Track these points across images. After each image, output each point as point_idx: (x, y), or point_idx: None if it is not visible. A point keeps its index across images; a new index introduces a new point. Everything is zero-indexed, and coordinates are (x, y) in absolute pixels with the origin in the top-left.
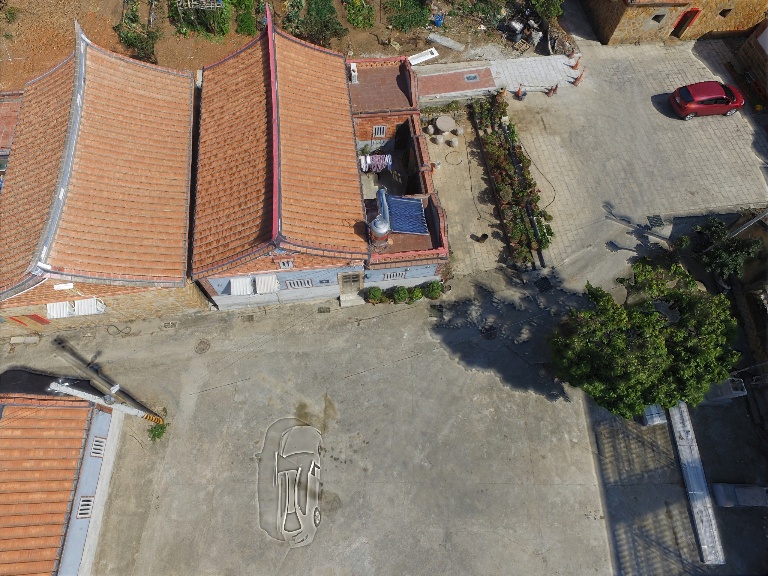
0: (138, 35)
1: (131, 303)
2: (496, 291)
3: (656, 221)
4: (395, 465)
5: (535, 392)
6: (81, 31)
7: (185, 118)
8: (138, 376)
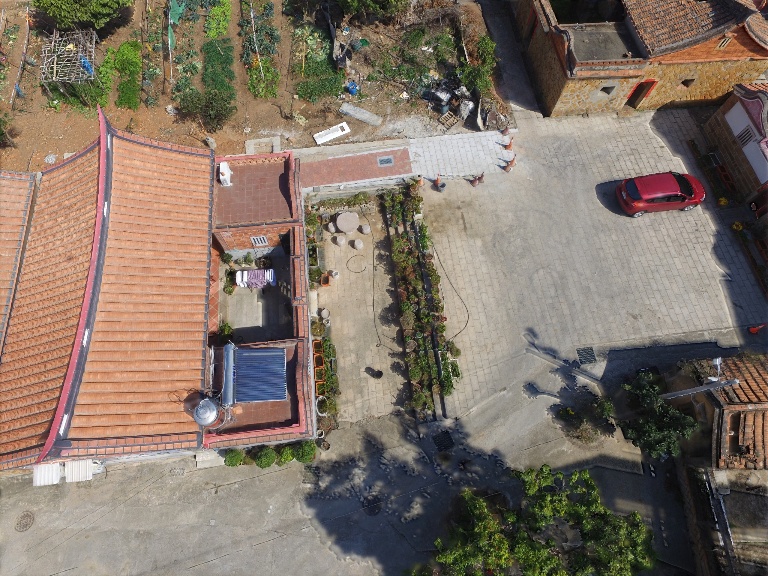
0: None
1: None
2: (386, 448)
3: (587, 355)
4: None
5: None
6: None
7: (13, 237)
8: None
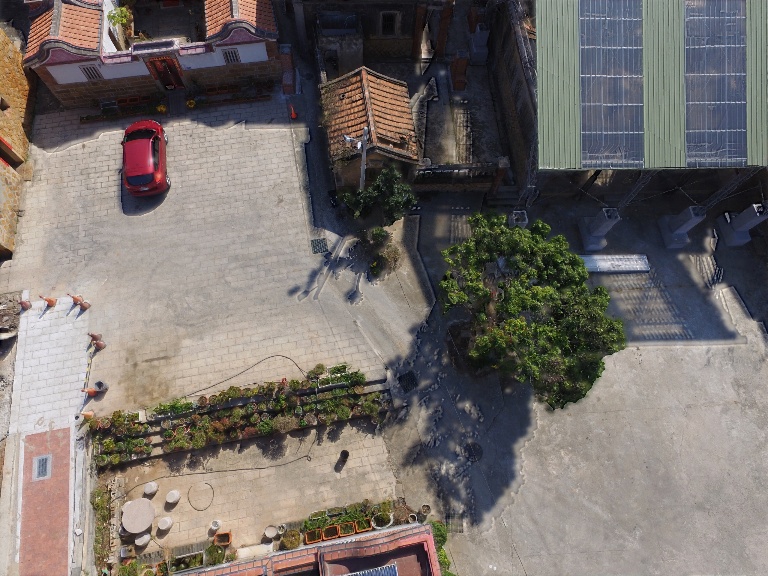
0: None
1: None
2: (420, 441)
3: (319, 245)
4: (648, 573)
5: (534, 402)
6: None
7: None
8: None
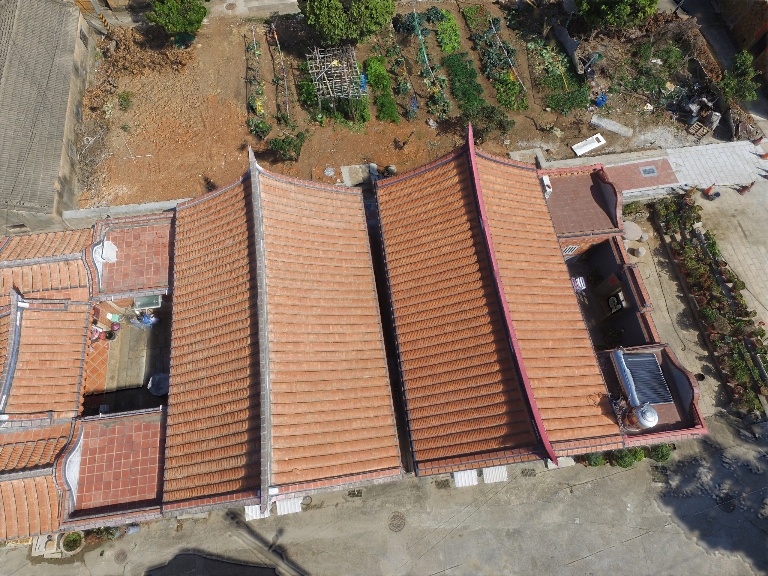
0: (287, 137)
1: None
2: (724, 448)
3: None
4: None
5: None
6: (254, 159)
7: (363, 249)
8: (330, 563)
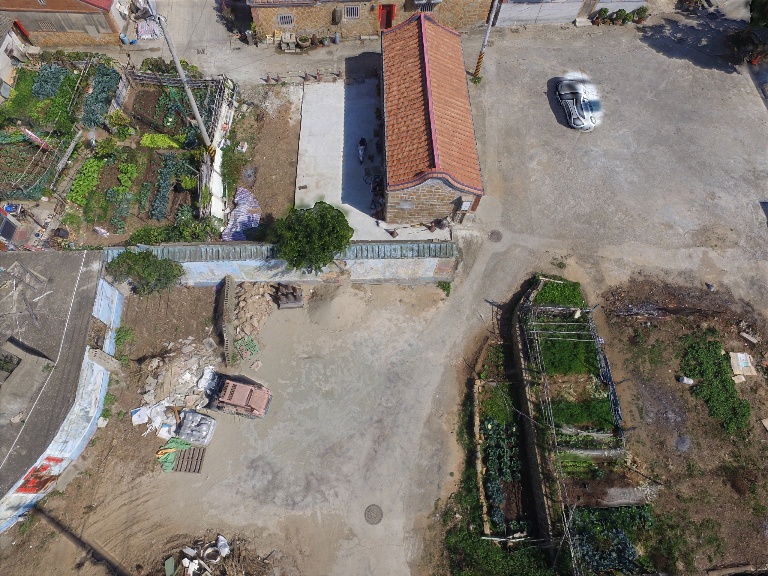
0: None
1: (454, 2)
2: (680, 20)
3: None
4: (635, 99)
5: (717, 69)
6: None
7: None
8: None
